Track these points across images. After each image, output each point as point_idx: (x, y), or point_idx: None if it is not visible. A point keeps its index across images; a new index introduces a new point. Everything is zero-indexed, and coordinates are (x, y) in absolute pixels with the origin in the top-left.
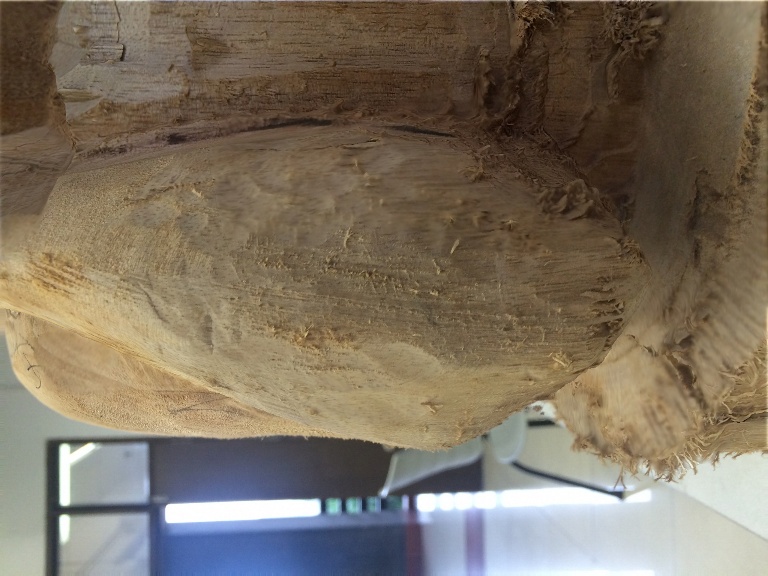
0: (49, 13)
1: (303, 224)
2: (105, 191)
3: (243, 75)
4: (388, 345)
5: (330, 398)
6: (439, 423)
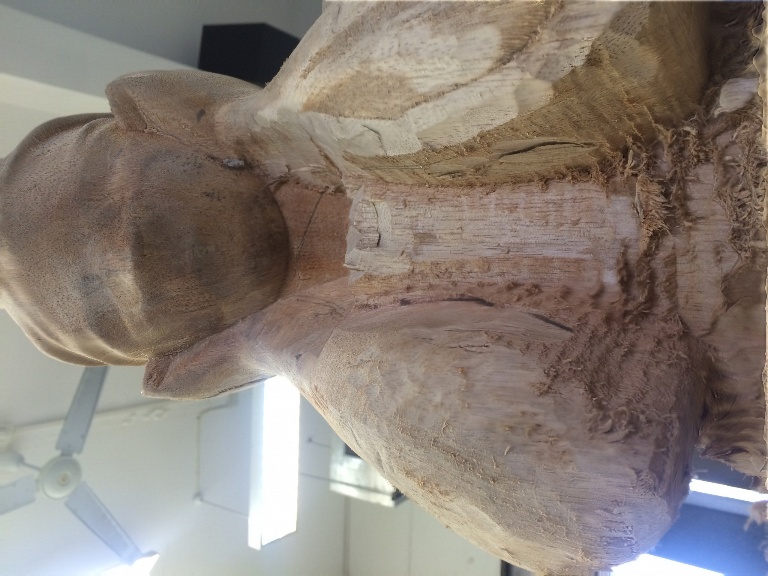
0: (349, 203)
1: (423, 410)
2: (343, 353)
3: (446, 259)
4: (469, 506)
5: (452, 523)
6: None
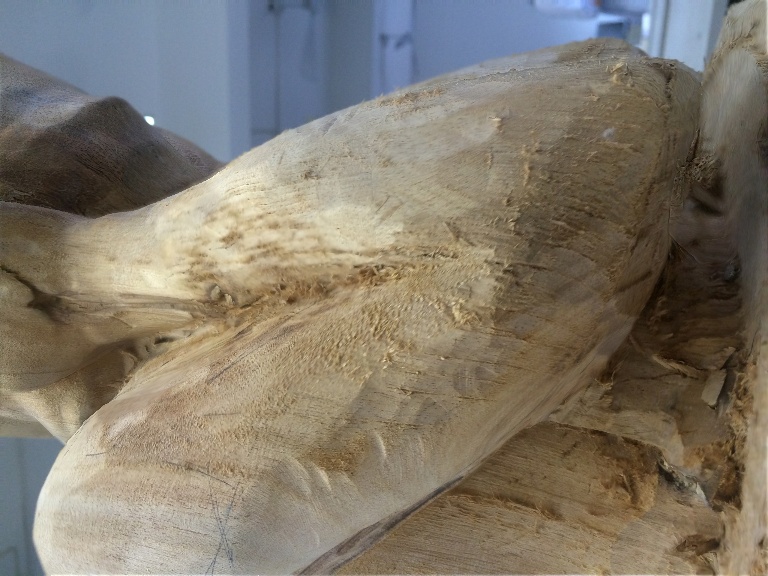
0: None
1: None
2: None
3: None
4: None
5: (406, 141)
6: (505, 150)
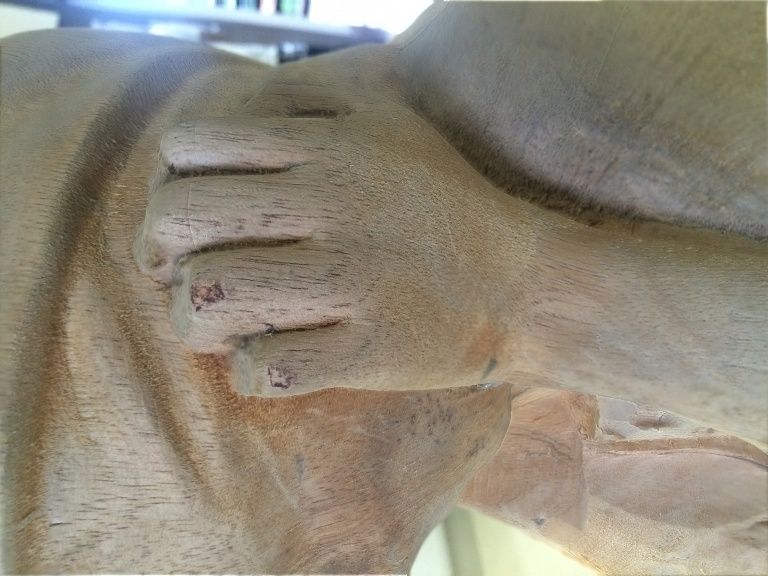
0: None
1: None
2: (638, 543)
3: None
4: None
5: None
6: None
